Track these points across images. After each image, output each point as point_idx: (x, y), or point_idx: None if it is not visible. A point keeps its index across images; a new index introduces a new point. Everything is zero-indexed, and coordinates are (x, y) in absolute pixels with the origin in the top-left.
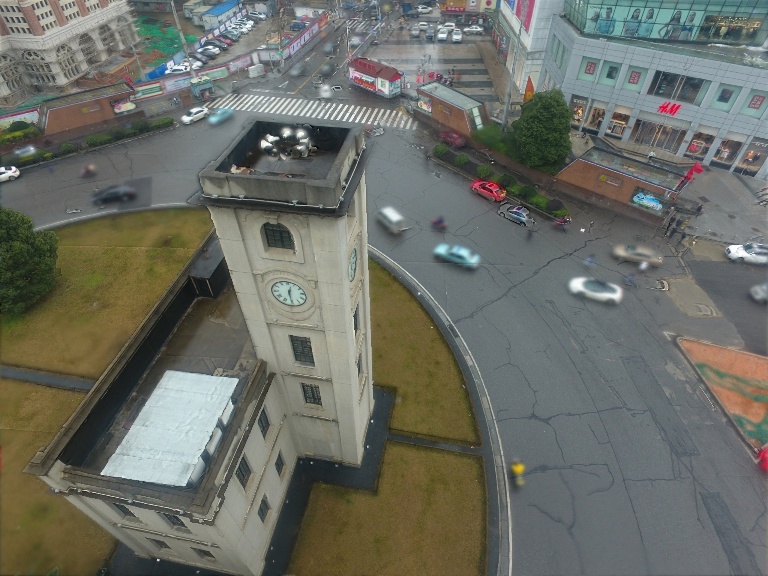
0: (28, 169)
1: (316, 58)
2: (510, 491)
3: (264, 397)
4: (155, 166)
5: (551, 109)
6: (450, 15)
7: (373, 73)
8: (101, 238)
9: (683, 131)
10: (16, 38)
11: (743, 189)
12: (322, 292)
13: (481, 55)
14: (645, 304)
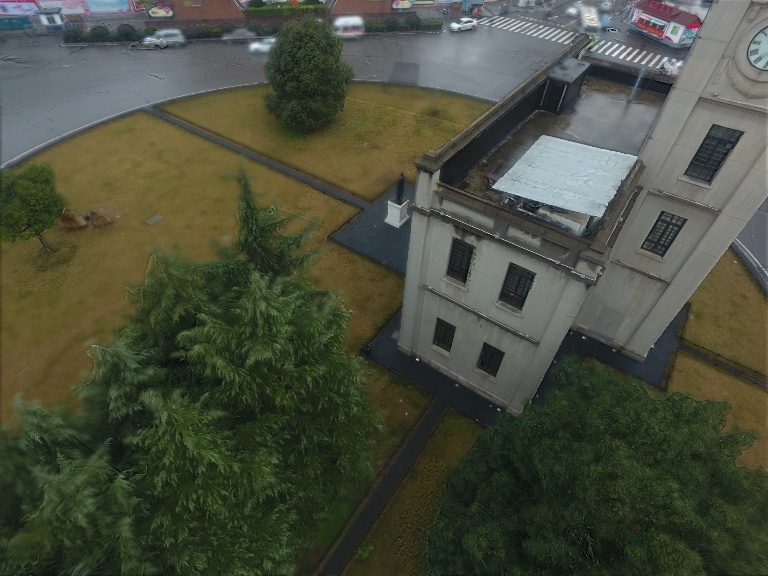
0: None
1: (589, 2)
2: None
3: (634, 202)
4: (423, 56)
5: None
6: None
7: (667, 16)
8: (373, 97)
9: None
10: None
11: None
12: None
13: None
14: None
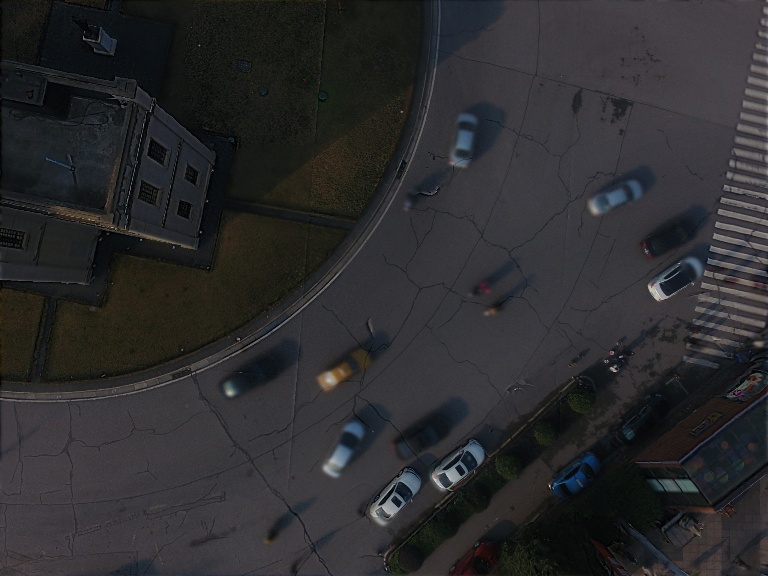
0: None
1: None
2: (3, 401)
3: None
4: None
5: None
6: None
7: None
8: None
9: None
10: None
11: None
12: None
13: None
14: None
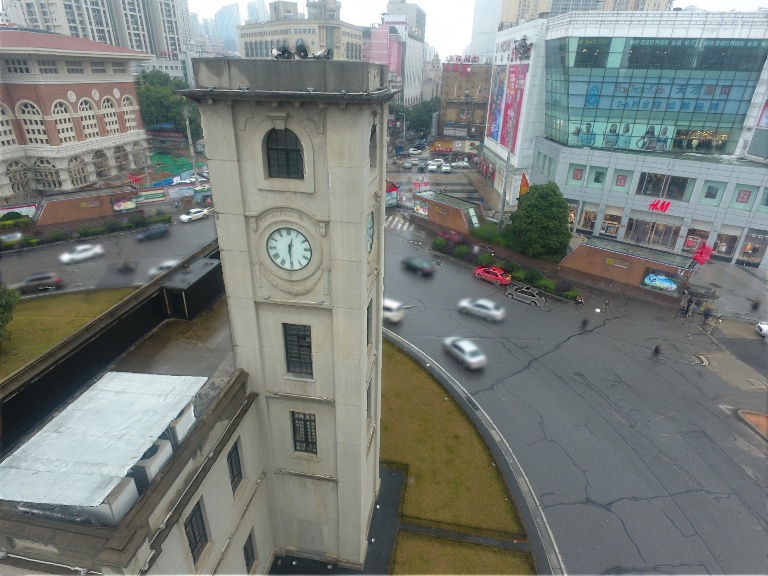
0: (9, 253)
1: None
2: None
3: (240, 419)
4: (145, 252)
5: (548, 198)
6: (438, 154)
7: None
8: (69, 310)
9: (677, 227)
10: (33, 147)
11: (751, 278)
12: (334, 239)
13: (469, 180)
14: (688, 378)
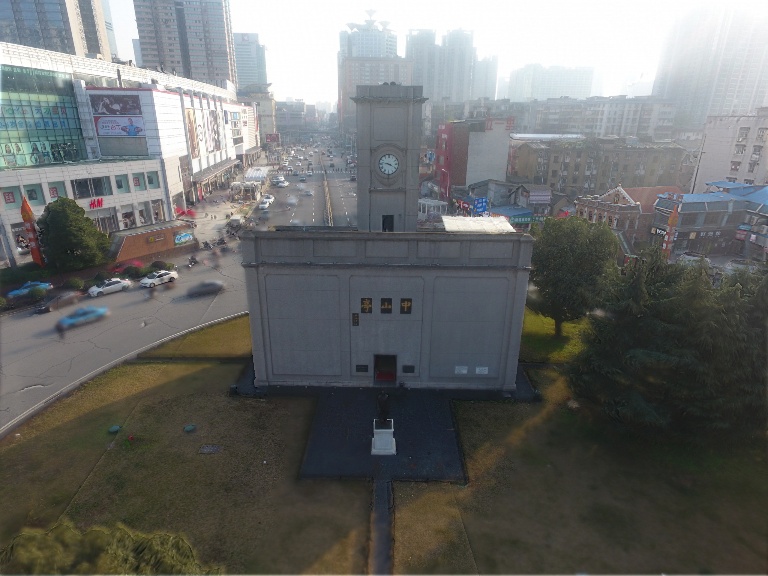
0: None
1: None
2: None
3: None
4: None
5: (78, 210)
6: None
7: None
8: None
9: (112, 216)
10: None
11: None
12: None
13: None
14: None
